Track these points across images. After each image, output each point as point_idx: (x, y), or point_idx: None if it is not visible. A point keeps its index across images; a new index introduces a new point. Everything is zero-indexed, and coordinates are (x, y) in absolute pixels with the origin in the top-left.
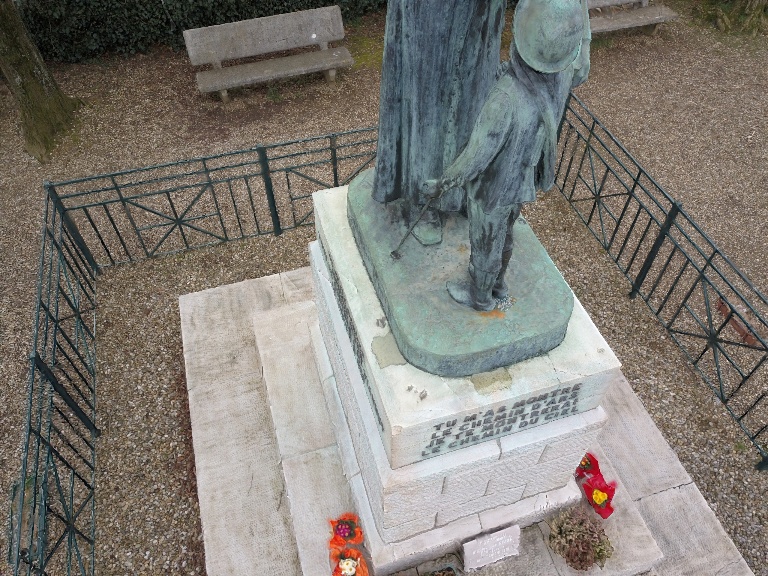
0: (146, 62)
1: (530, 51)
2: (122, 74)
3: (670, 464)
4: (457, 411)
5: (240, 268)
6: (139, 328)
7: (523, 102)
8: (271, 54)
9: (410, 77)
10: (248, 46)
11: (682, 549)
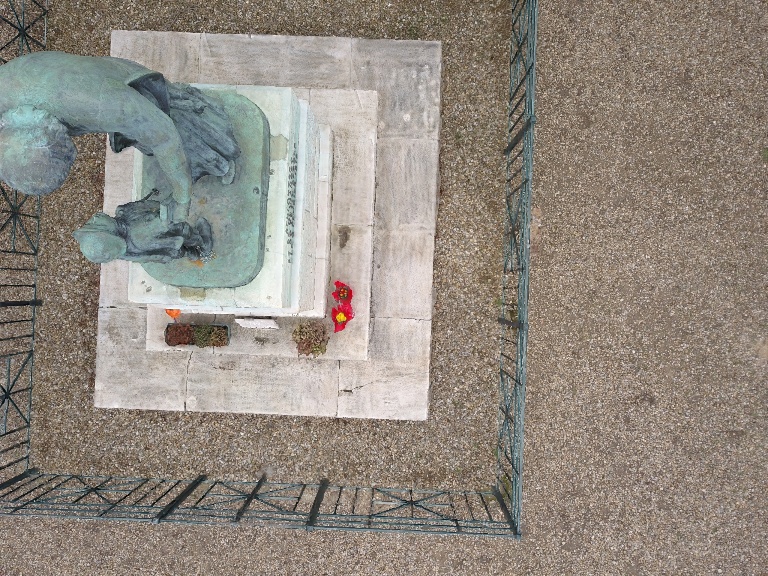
0: None
1: None
2: None
3: (423, 304)
4: (168, 303)
5: (177, 5)
6: (83, 44)
7: None
8: None
9: None
10: None
11: (395, 355)
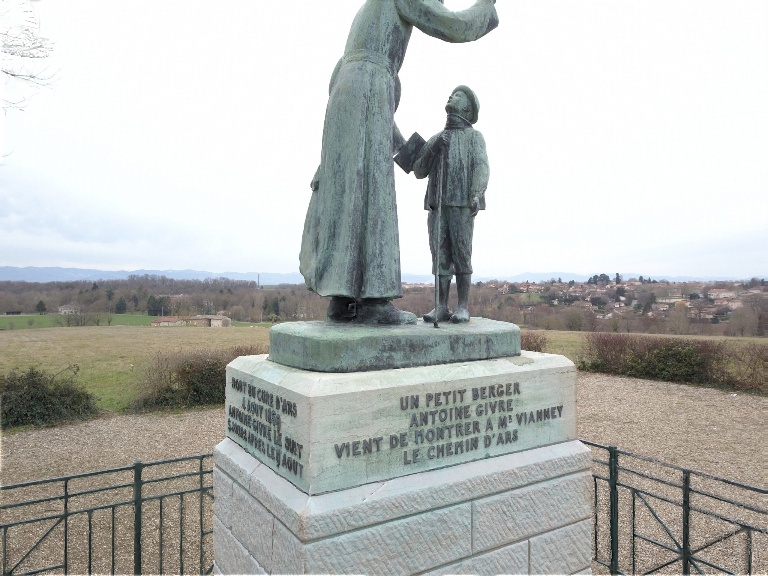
0: None
1: None
2: None
3: None
4: None
5: None
6: None
7: None
8: None
9: None
10: None
11: None
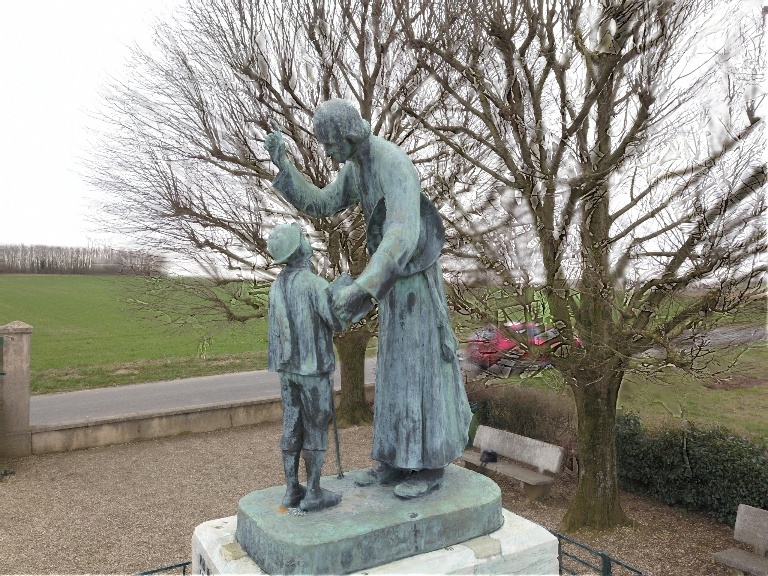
0: (724, 532)
1: None
2: (691, 528)
3: None
4: None
5: None
6: None
7: None
8: None
9: None
10: None
11: None
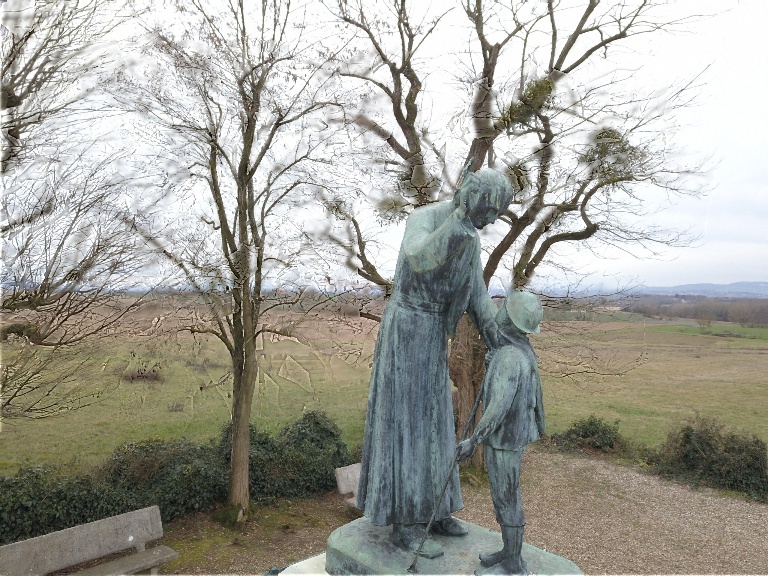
0: None
1: (520, 322)
2: None
3: None
4: None
5: None
6: None
7: (522, 356)
8: (80, 565)
9: (401, 401)
10: (53, 560)
11: None
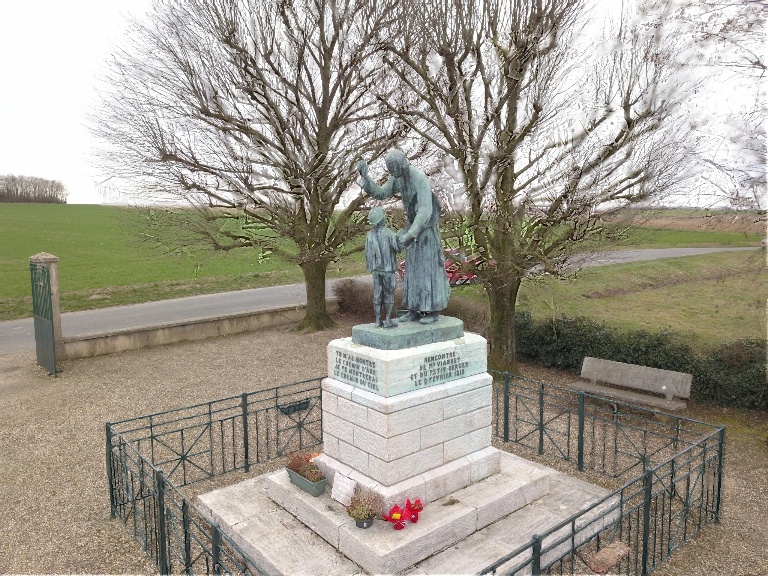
0: (578, 379)
1: None
2: (559, 378)
3: None
4: None
5: None
6: None
7: None
8: (630, 388)
9: None
10: (617, 378)
11: None
